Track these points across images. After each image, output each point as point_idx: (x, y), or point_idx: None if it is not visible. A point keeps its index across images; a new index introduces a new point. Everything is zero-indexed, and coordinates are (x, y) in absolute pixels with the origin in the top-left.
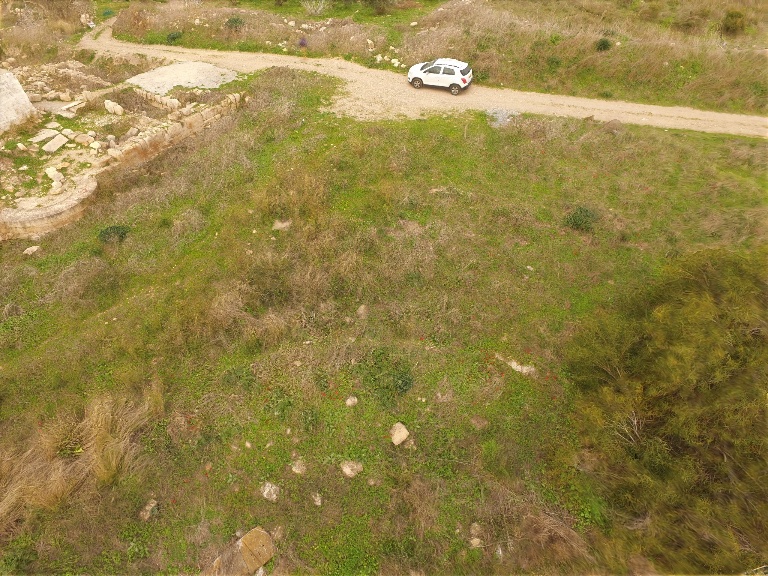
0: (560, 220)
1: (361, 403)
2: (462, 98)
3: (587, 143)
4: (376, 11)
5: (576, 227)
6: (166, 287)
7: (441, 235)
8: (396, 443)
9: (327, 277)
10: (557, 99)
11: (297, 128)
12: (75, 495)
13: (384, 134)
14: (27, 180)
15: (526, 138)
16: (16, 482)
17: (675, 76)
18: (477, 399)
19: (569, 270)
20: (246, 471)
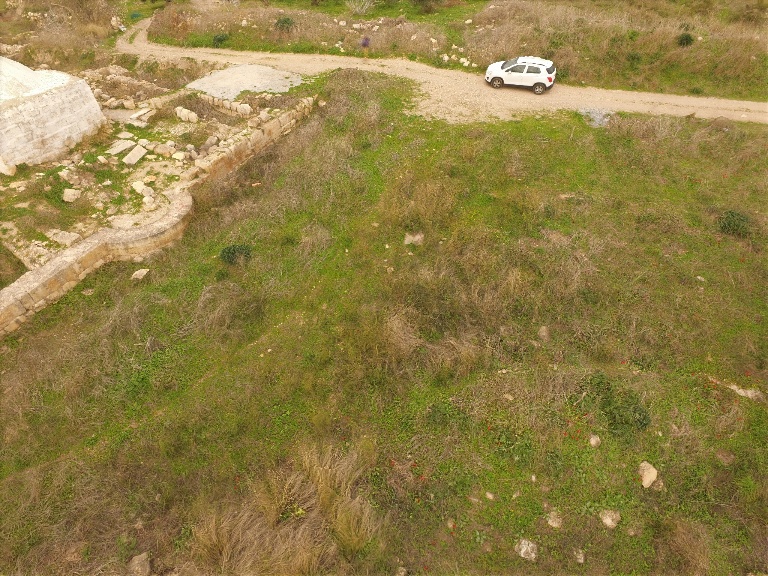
0: (711, 225)
1: (603, 442)
2: (547, 97)
3: (702, 142)
4: (423, 9)
5: (732, 232)
6: (314, 312)
7: (592, 245)
8: (646, 485)
9: (498, 296)
10: (646, 97)
11: (390, 133)
12: (323, 569)
13: (487, 137)
14: (115, 196)
15: (635, 138)
16: (239, 554)
17: (764, 71)
18: (718, 430)
19: (743, 279)
20: (496, 527)
